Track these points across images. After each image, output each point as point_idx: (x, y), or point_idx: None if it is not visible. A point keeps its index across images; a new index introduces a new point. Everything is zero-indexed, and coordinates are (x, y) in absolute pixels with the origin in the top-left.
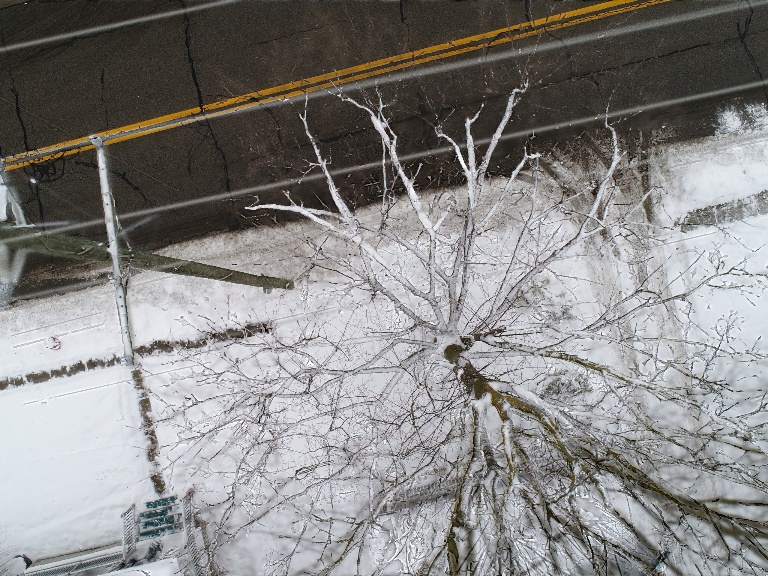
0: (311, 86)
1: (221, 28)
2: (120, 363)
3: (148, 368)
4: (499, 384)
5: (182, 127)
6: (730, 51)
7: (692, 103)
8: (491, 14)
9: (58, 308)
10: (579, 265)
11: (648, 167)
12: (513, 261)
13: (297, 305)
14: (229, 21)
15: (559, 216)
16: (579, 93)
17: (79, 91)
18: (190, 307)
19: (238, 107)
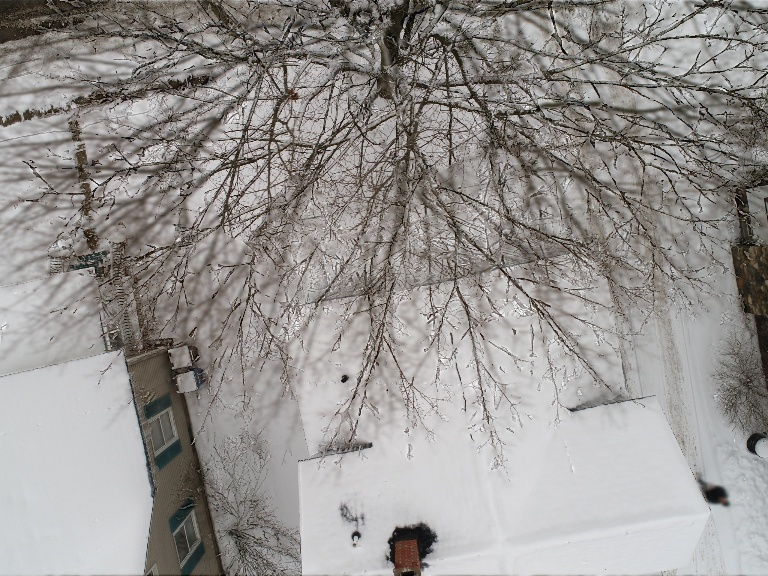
0: None
1: None
2: None
3: (86, 119)
4: None
5: None
6: None
7: None
8: None
9: None
10: (532, 19)
11: None
12: None
13: None
14: None
15: None
16: None
17: None
18: (131, 55)
19: None
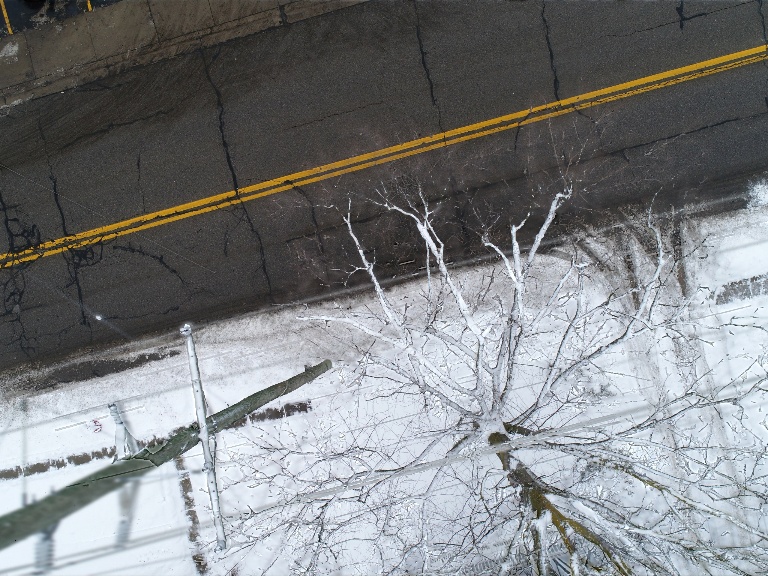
0: (344, 168)
1: (254, 113)
2: None
3: None
4: (556, 497)
5: (218, 210)
6: (759, 125)
7: (723, 177)
8: (521, 94)
9: (98, 390)
10: None
11: (681, 241)
12: (558, 357)
13: None
14: (262, 106)
15: (594, 291)
16: (610, 170)
17: (116, 177)
18: (229, 388)
19: (273, 190)
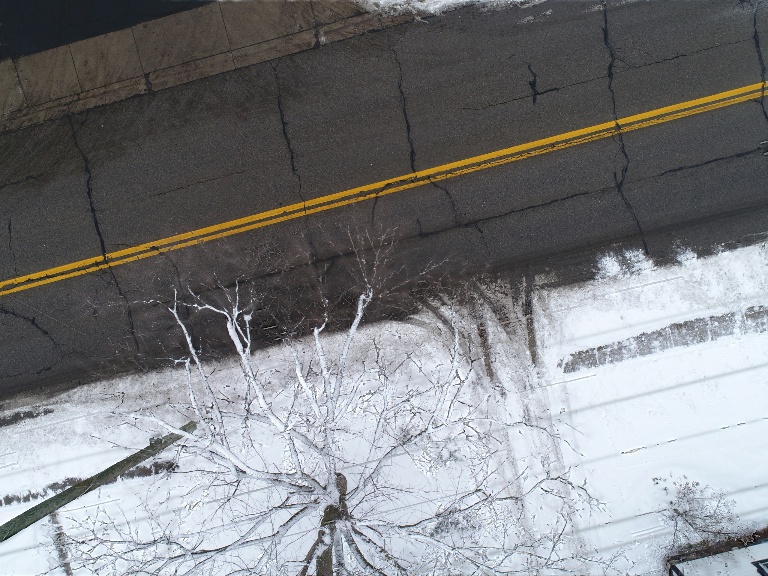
0: (208, 235)
1: (121, 180)
2: None
3: None
4: None
5: (87, 275)
6: (608, 199)
7: (573, 249)
8: (378, 165)
9: None
10: None
11: (532, 310)
12: (374, 444)
13: (160, 504)
14: (128, 173)
15: (448, 358)
16: (464, 241)
17: None
18: (99, 447)
19: (139, 255)
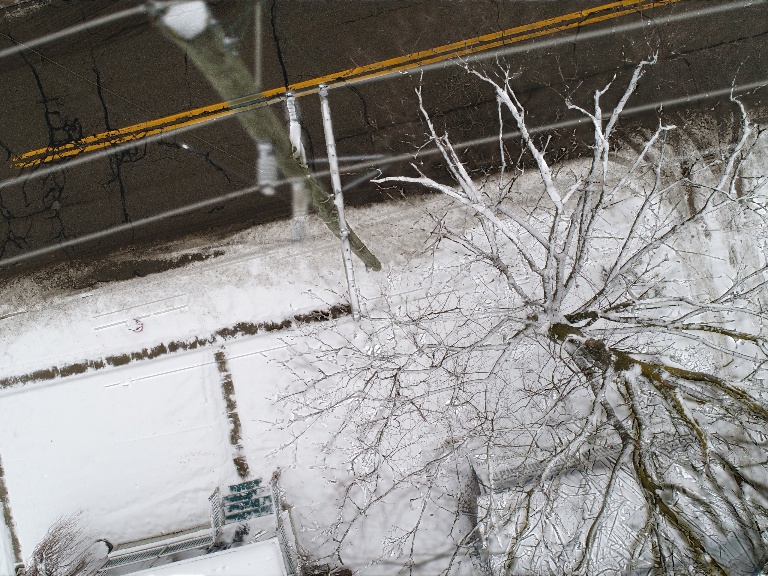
0: (399, 66)
1: (307, 7)
2: (353, 316)
3: (231, 350)
4: (641, 356)
5: (267, 107)
6: None
7: None
8: None
9: (139, 290)
10: None
11: None
12: None
13: None
14: None
15: None
16: (670, 73)
17: (162, 70)
18: (275, 289)
19: None
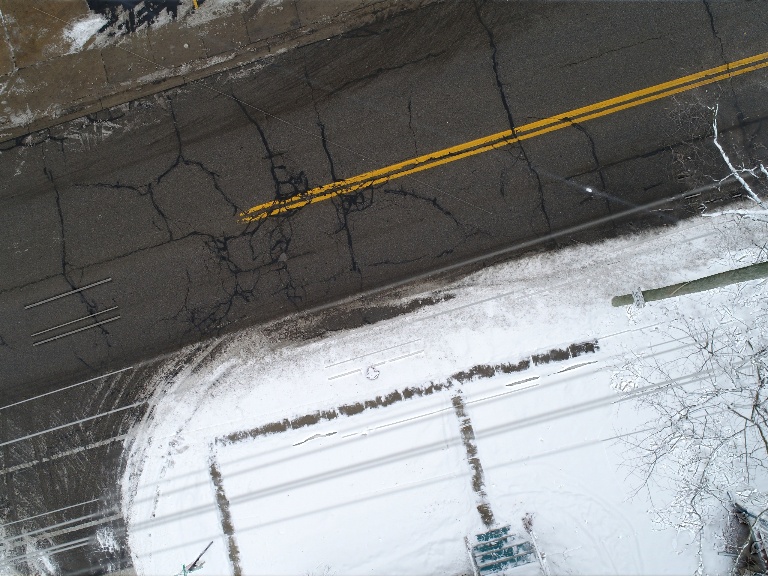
0: (625, 103)
1: (529, 52)
2: None
3: (469, 394)
4: None
5: (494, 150)
6: None
7: None
8: None
9: (372, 337)
10: None
11: None
12: None
13: (765, 311)
14: (537, 45)
15: None
16: None
17: (386, 121)
18: (513, 329)
19: (551, 128)
